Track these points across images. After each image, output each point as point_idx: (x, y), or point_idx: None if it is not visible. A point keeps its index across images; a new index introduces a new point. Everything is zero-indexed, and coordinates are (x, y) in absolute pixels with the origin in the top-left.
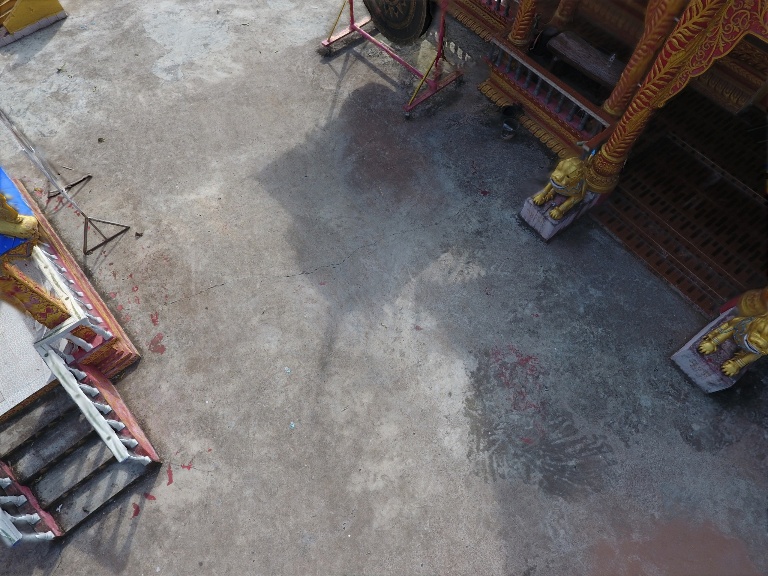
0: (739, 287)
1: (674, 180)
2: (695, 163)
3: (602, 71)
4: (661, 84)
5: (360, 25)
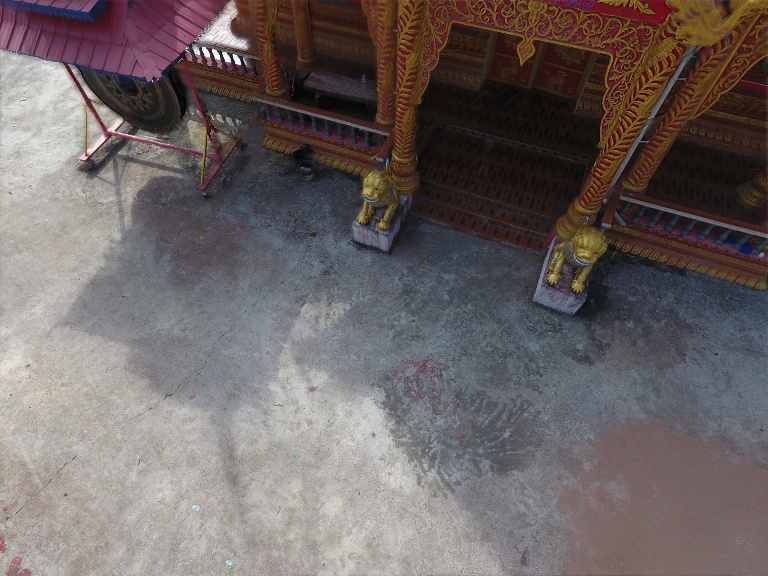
0: (550, 220)
1: (461, 158)
2: (469, 139)
3: (361, 93)
4: (410, 85)
5: (114, 129)
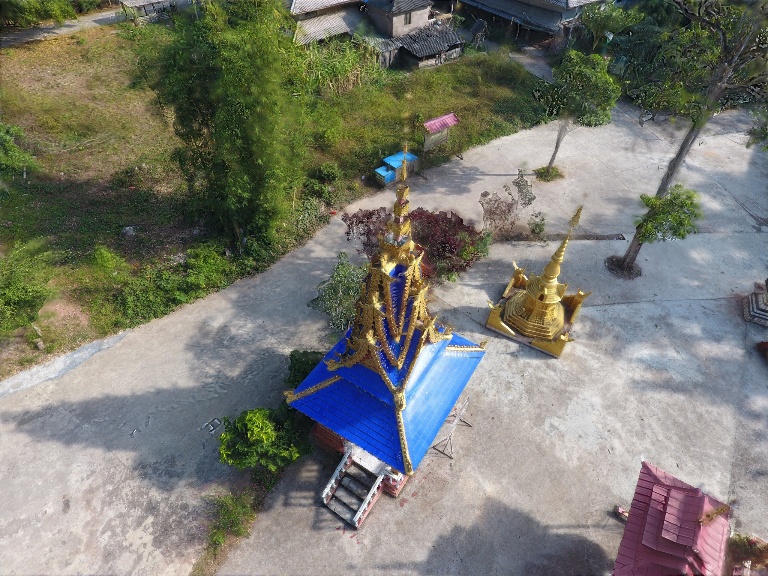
0: None
1: None
2: None
3: None
4: None
5: None
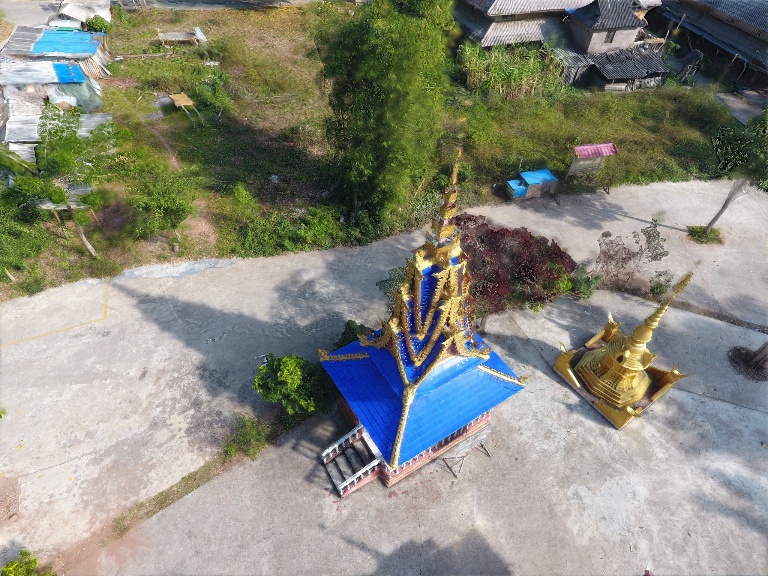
0: None
1: None
2: None
3: None
4: None
5: None
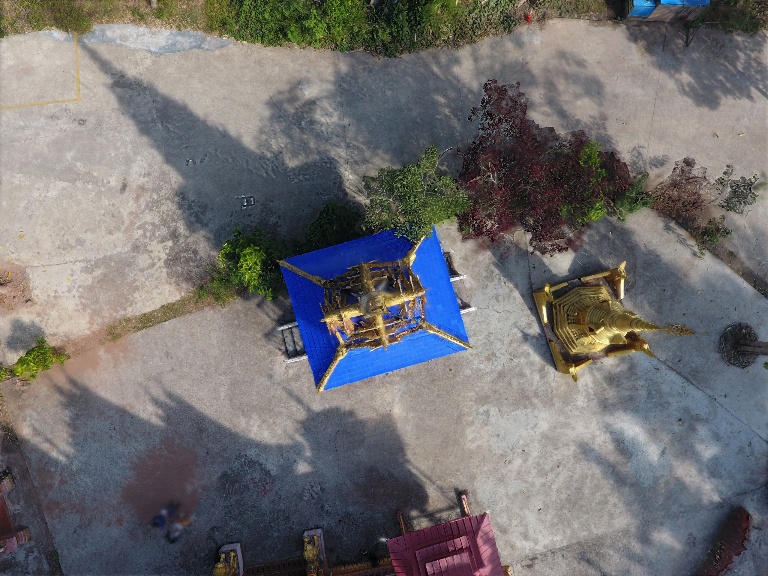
0: None
1: None
2: None
3: None
4: None
5: None
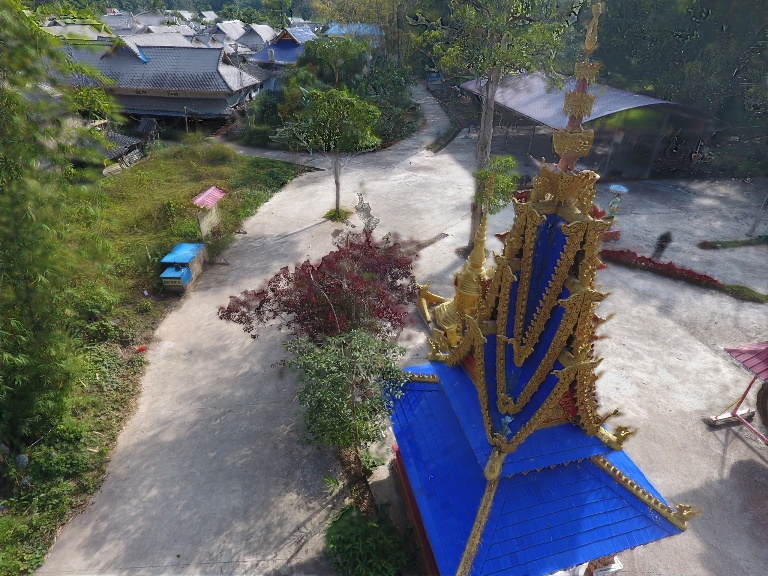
0: None
1: None
2: None
3: None
4: None
5: (739, 414)
